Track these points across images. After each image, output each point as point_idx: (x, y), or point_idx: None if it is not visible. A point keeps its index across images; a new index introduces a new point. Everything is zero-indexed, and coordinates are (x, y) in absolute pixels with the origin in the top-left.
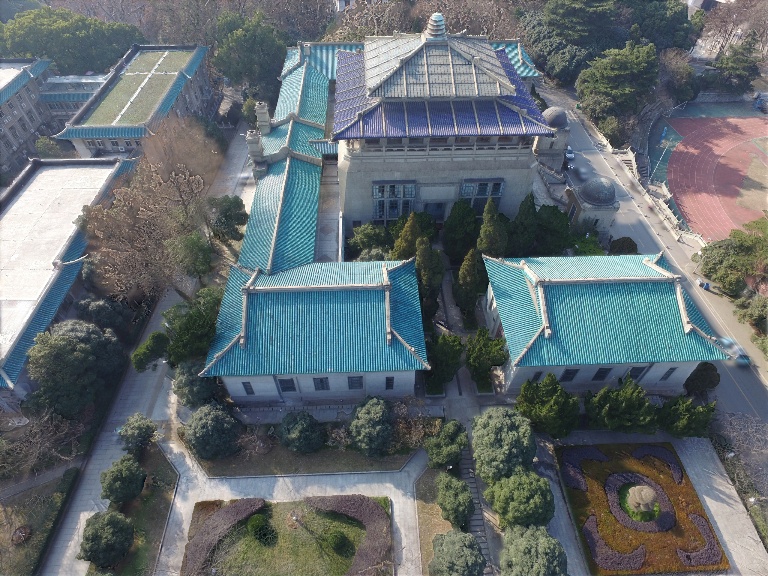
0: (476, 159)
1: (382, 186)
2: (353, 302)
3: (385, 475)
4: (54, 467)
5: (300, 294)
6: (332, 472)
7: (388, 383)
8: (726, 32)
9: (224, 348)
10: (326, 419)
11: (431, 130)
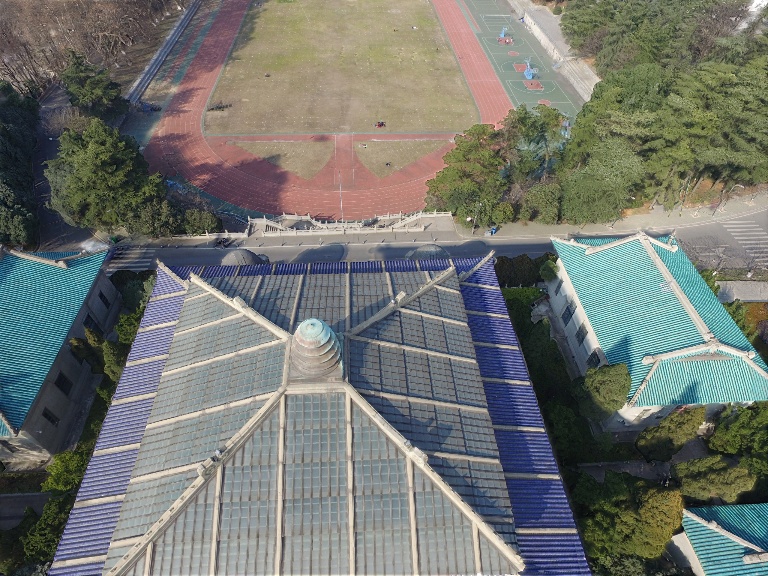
0: None
1: None
2: None
3: None
4: None
5: None
6: None
7: None
8: None
9: None
10: None
11: (534, 427)
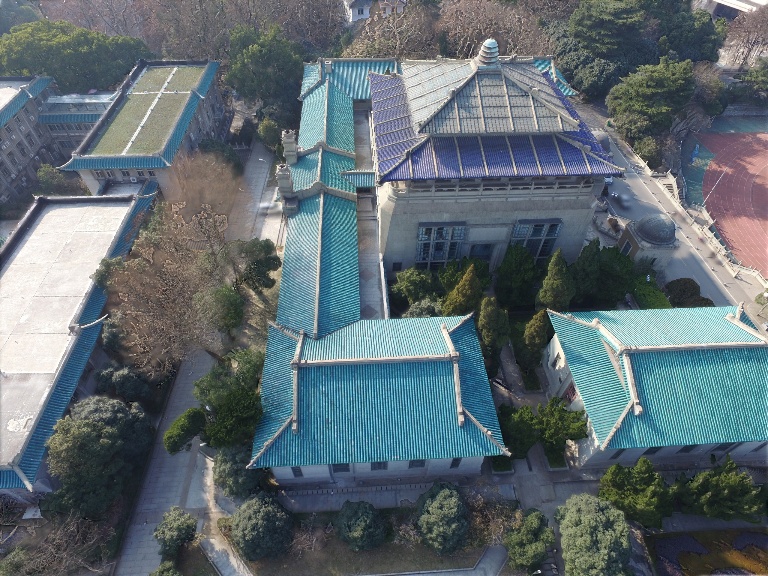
0: (533, 199)
1: (429, 228)
2: (418, 376)
3: (458, 574)
4: (79, 574)
5: (357, 367)
6: (398, 572)
7: (454, 462)
8: (750, 42)
9: (273, 433)
10: (384, 503)
11: (488, 170)
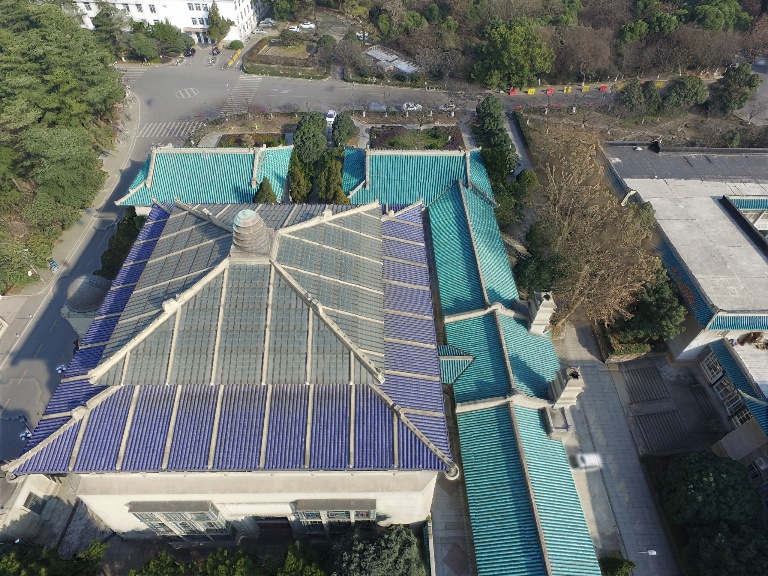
0: None
1: None
2: None
3: None
4: None
5: None
6: None
7: None
8: None
9: None
10: None
11: None
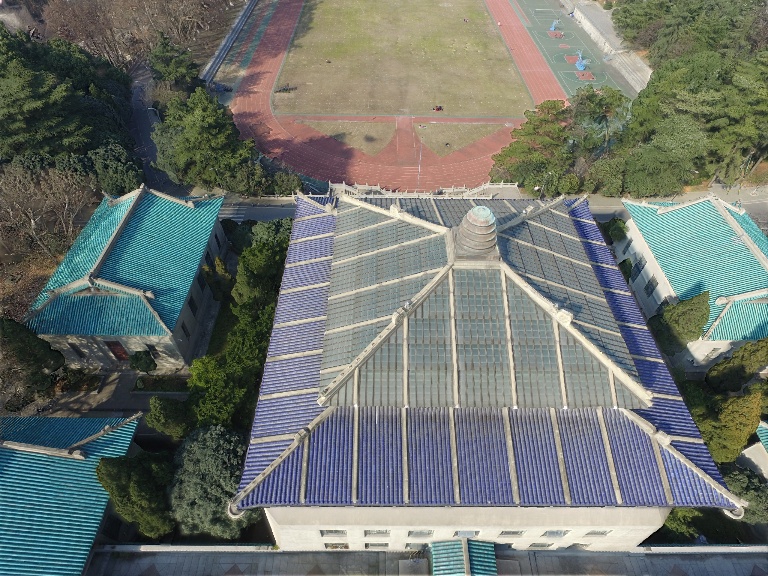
0: None
1: None
2: None
3: None
4: None
5: None
6: None
7: None
8: None
9: None
10: None
11: (639, 325)
